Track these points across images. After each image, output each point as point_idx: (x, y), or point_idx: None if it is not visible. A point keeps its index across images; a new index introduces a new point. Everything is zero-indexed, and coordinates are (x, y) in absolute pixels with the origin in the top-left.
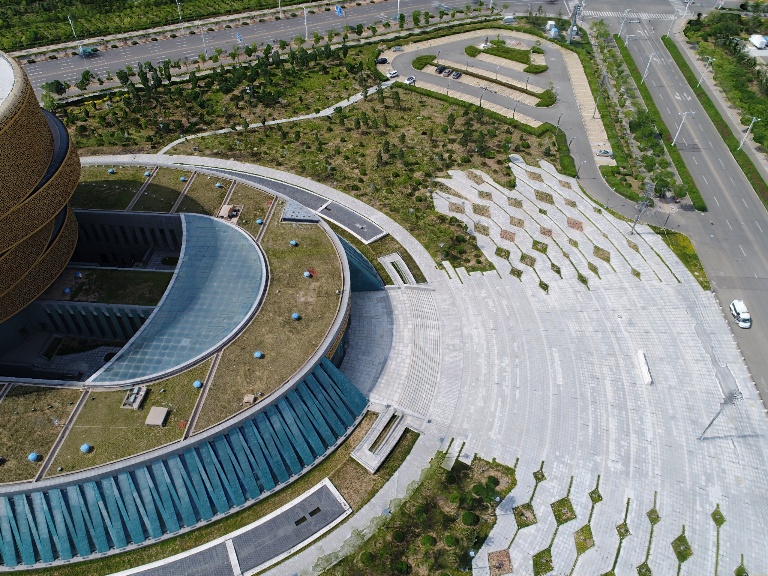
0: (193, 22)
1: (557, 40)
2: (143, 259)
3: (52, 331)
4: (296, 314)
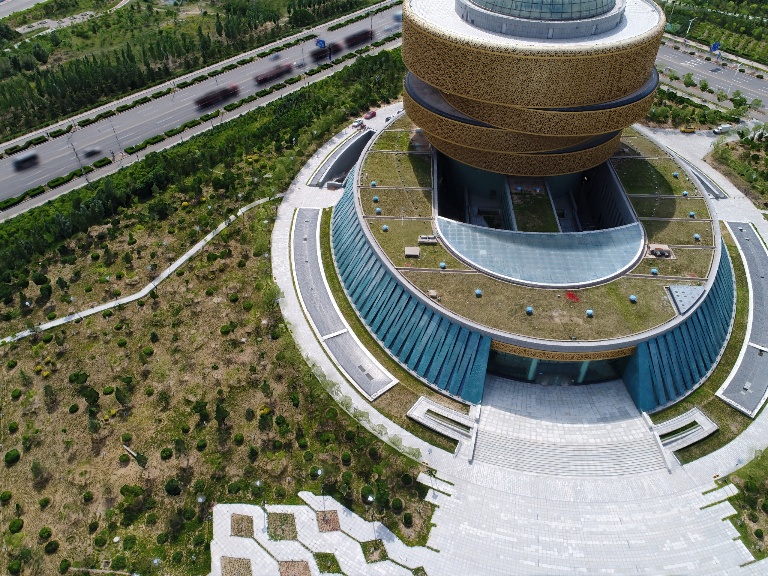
0: None
1: None
2: None
3: None
4: (531, 309)
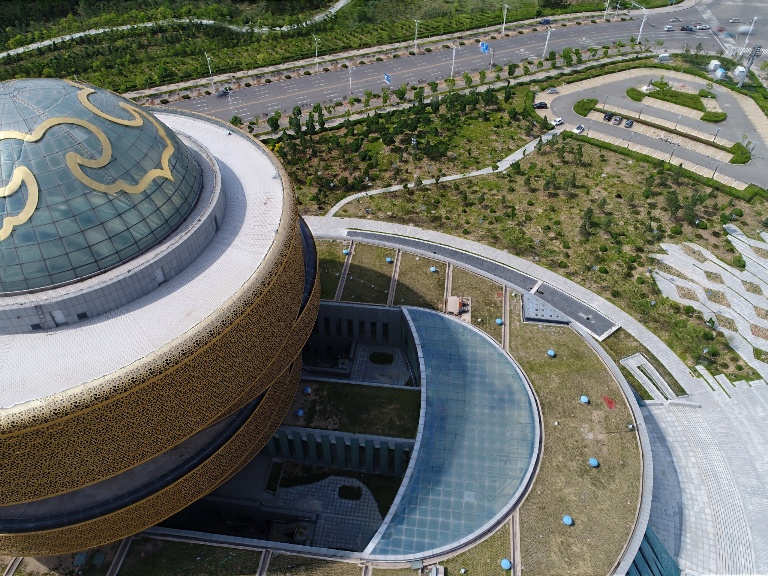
0: (323, 57)
1: (725, 82)
2: (350, 356)
3: (272, 455)
4: (595, 460)
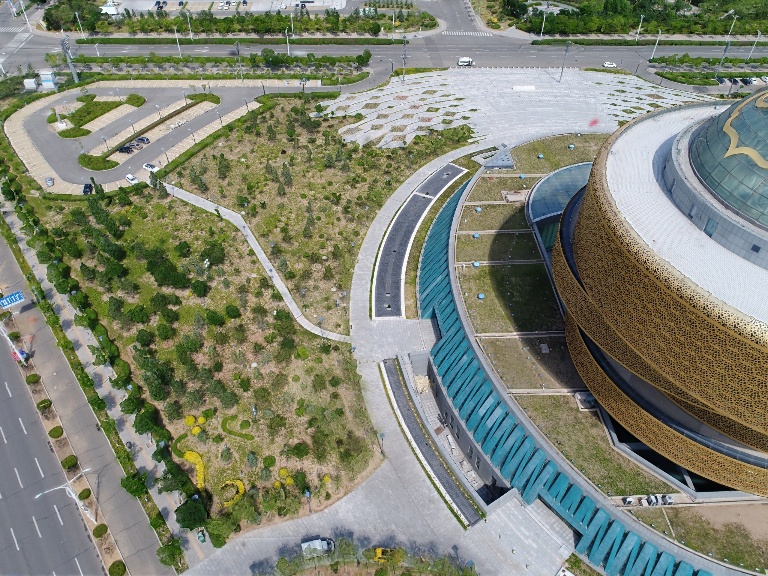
0: None
1: (65, 86)
2: None
3: None
4: None
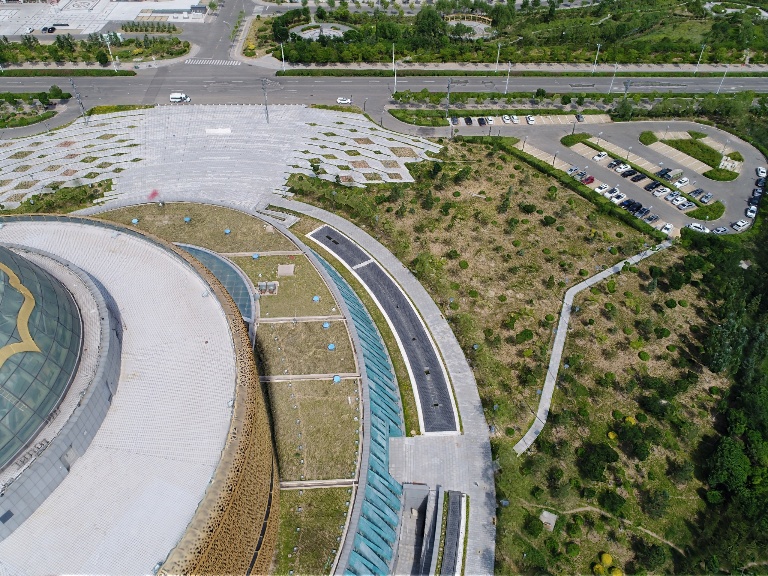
0: None
1: None
2: None
3: None
4: (186, 218)
